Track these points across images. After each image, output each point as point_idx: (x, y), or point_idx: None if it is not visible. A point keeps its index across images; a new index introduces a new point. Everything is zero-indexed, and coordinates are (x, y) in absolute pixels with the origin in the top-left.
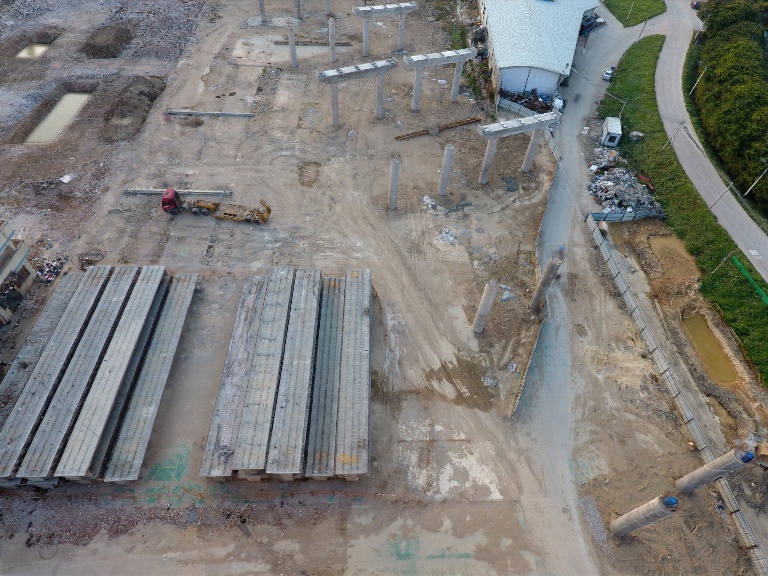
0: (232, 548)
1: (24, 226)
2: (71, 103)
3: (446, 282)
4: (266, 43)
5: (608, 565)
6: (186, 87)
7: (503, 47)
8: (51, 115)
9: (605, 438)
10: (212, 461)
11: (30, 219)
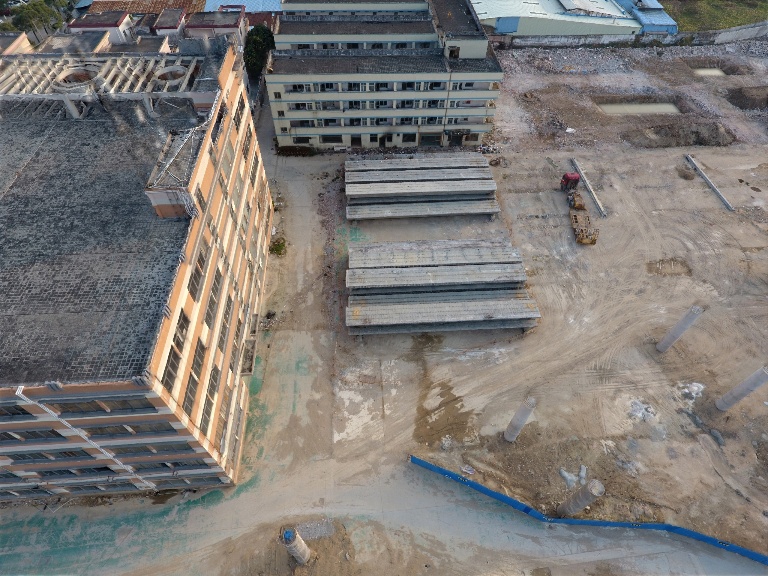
0: (311, 272)
1: (518, 128)
2: (660, 109)
3: (565, 405)
4: None
5: (274, 535)
6: (737, 158)
7: None
8: (638, 105)
9: (394, 569)
10: (358, 248)
11: (525, 128)
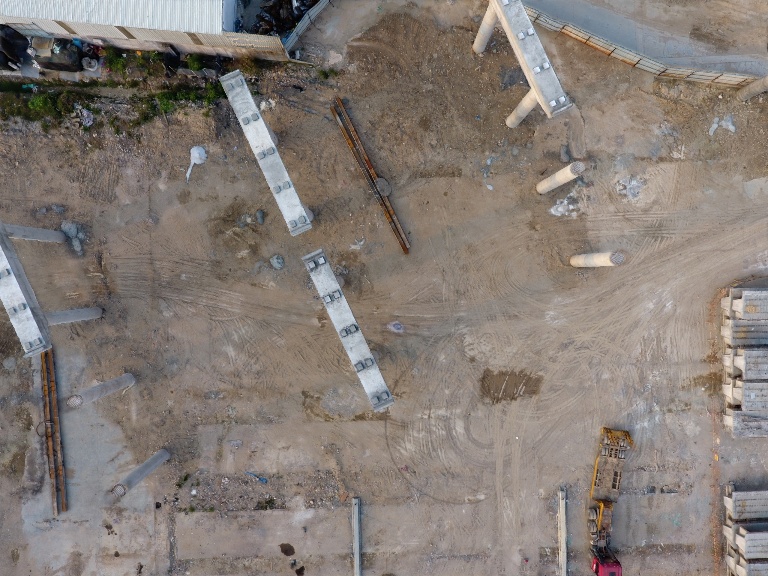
0: None
1: None
2: None
3: (709, 197)
4: (65, 529)
5: None
6: None
7: (125, 3)
8: None
9: None
10: None
11: None
